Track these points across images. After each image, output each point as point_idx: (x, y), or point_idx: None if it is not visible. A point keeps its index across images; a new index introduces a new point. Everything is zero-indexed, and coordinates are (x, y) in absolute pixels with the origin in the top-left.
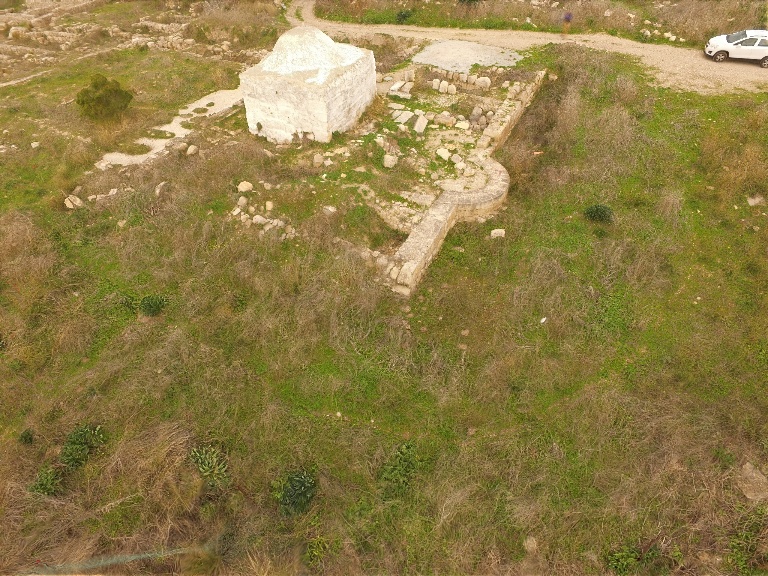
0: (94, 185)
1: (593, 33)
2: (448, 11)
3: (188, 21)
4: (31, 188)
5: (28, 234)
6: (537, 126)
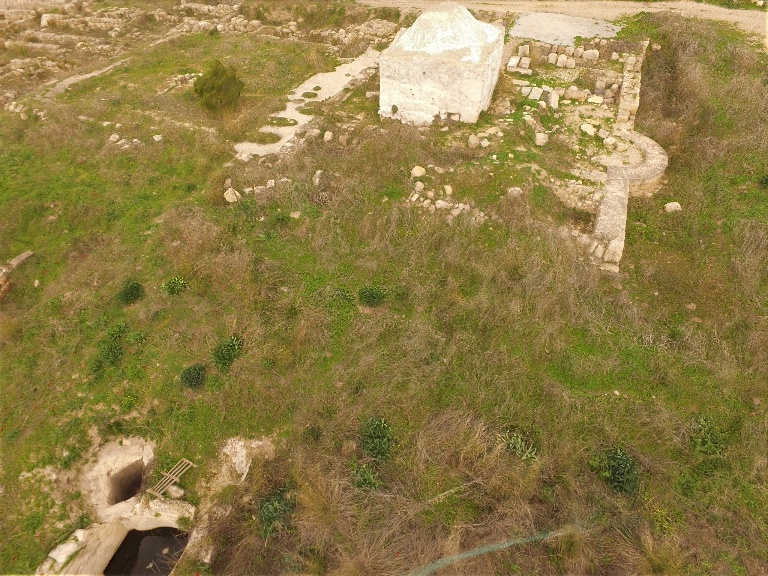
0: (244, 177)
1: (677, 0)
2: None
3: (230, 2)
4: (176, 183)
5: (205, 231)
6: (659, 97)
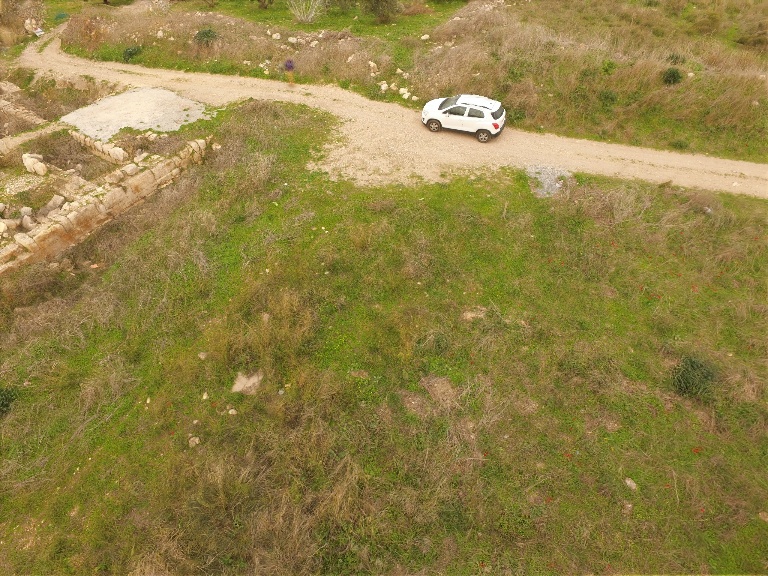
0: None
1: (324, 84)
2: (180, 49)
3: None
4: None
5: None
6: None
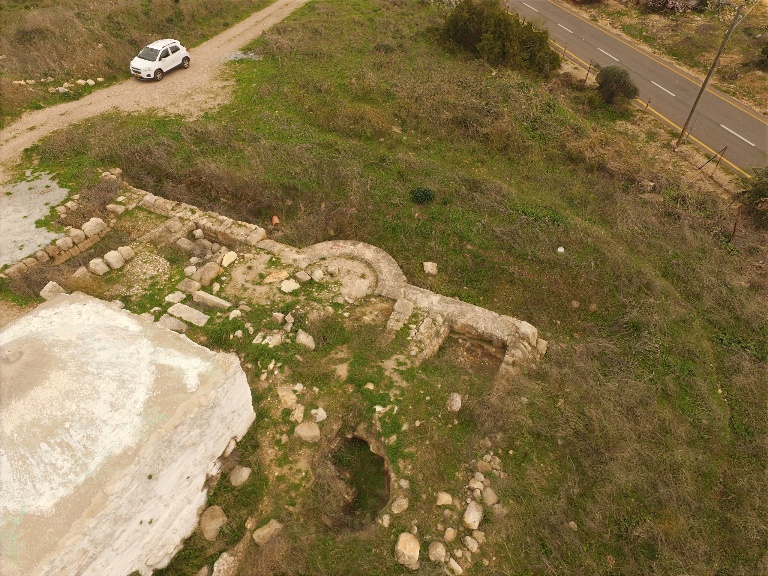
0: None
1: (18, 118)
2: None
3: None
4: None
5: None
6: None
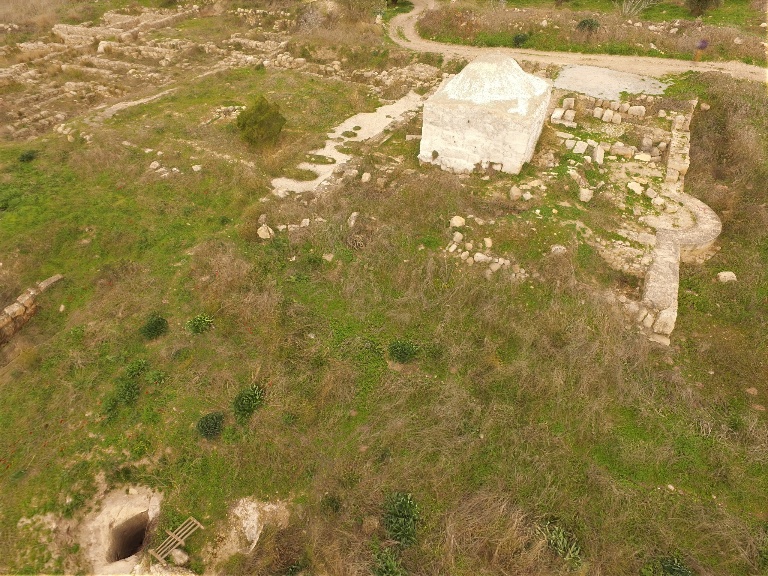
0: (279, 214)
1: (726, 61)
2: (567, 35)
3: (277, 38)
4: (210, 215)
5: (236, 267)
6: (709, 158)
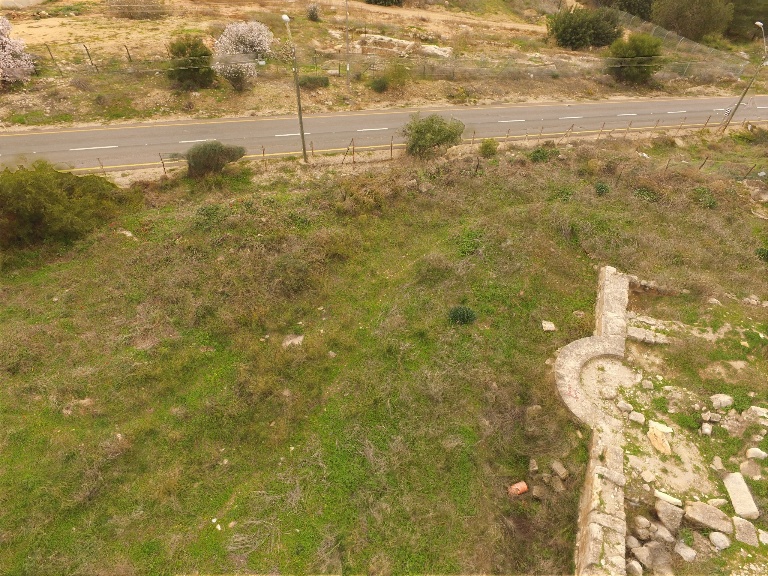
0: None
1: None
2: None
3: None
4: None
5: None
6: None
